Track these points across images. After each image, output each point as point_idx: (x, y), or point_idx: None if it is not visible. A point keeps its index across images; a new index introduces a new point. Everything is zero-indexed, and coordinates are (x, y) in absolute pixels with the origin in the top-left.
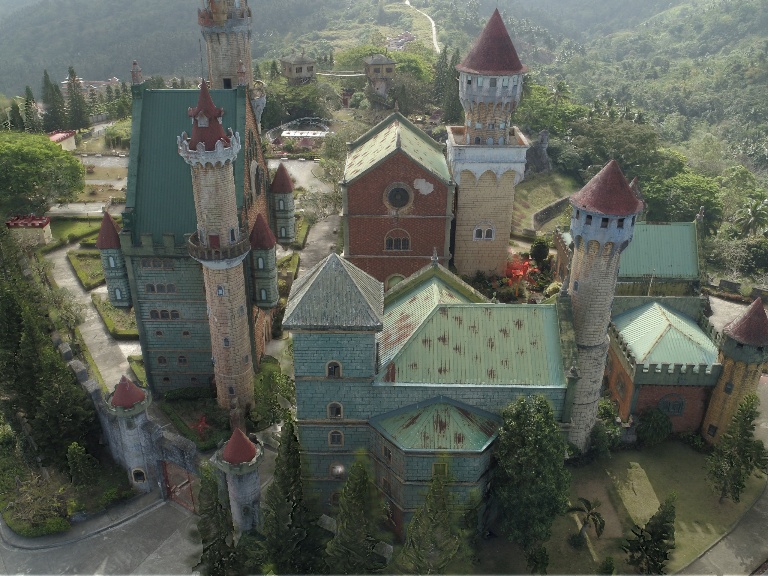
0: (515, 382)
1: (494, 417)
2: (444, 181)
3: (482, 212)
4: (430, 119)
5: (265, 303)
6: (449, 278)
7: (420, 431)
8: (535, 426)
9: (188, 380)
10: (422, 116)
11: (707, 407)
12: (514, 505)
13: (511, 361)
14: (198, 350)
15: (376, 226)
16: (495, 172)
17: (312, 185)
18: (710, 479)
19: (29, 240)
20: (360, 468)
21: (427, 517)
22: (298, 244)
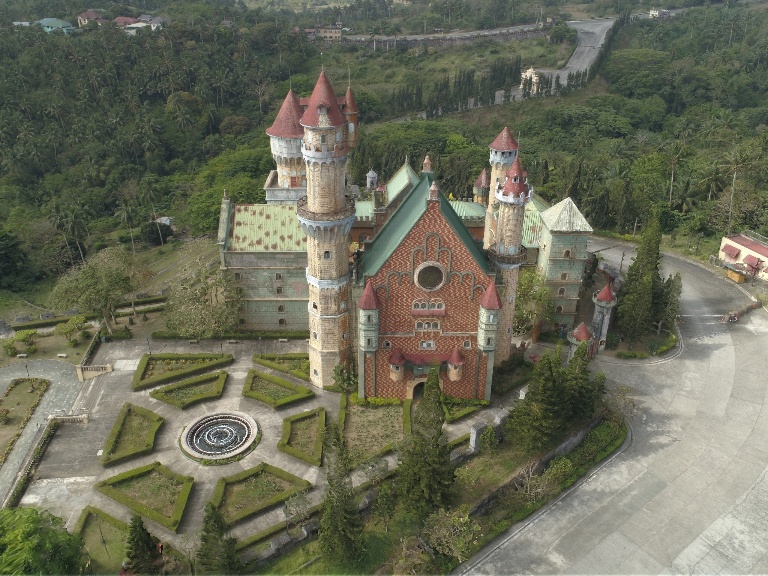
0: None
1: None
2: None
3: None
4: None
5: None
6: None
7: None
8: None
9: None
10: None
11: None
12: None
13: None
14: None
15: None
16: None
17: (1, 377)
18: None
19: None
20: None
21: None
22: None
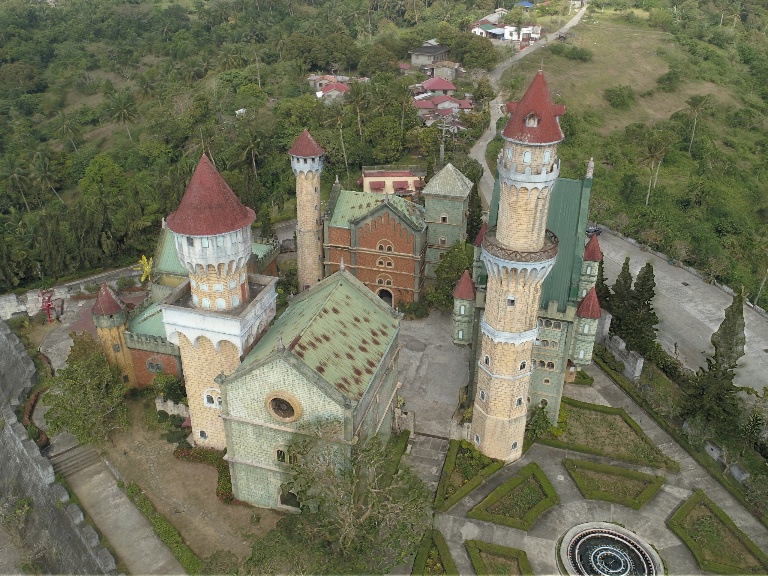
0: None
1: None
2: None
3: None
4: None
5: None
6: None
7: None
8: None
9: None
10: None
11: None
12: None
13: None
14: None
15: None
16: None
17: None
18: None
19: None
20: None
21: None
22: (433, 529)
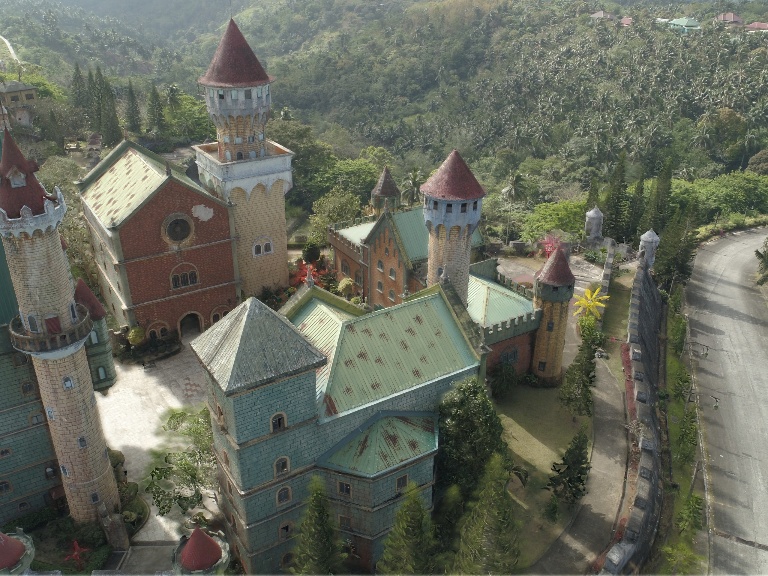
0: (439, 374)
1: (425, 414)
2: (224, 203)
3: (257, 227)
4: (90, 145)
5: (105, 383)
6: (327, 295)
7: (377, 453)
8: (481, 407)
9: (15, 509)
10: (75, 143)
11: (534, 348)
12: (469, 488)
13: (428, 356)
14: (24, 467)
15: (158, 266)
16: (265, 184)
17: None
18: (566, 405)
19: None
20: (417, 503)
21: (496, 521)
22: None
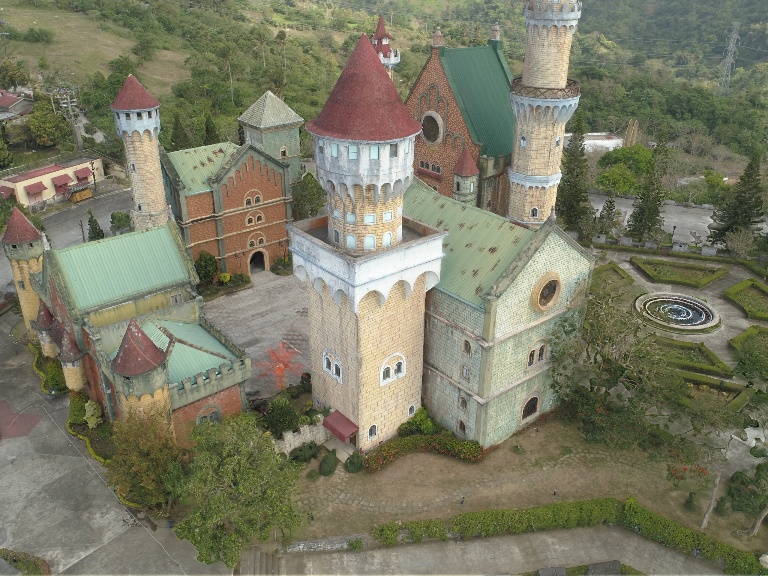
0: None
1: None
2: None
3: None
4: None
5: None
6: None
7: None
8: None
9: None
10: None
11: None
12: None
13: None
14: None
15: None
16: None
17: None
18: None
19: (747, 246)
20: None
21: None
22: None
